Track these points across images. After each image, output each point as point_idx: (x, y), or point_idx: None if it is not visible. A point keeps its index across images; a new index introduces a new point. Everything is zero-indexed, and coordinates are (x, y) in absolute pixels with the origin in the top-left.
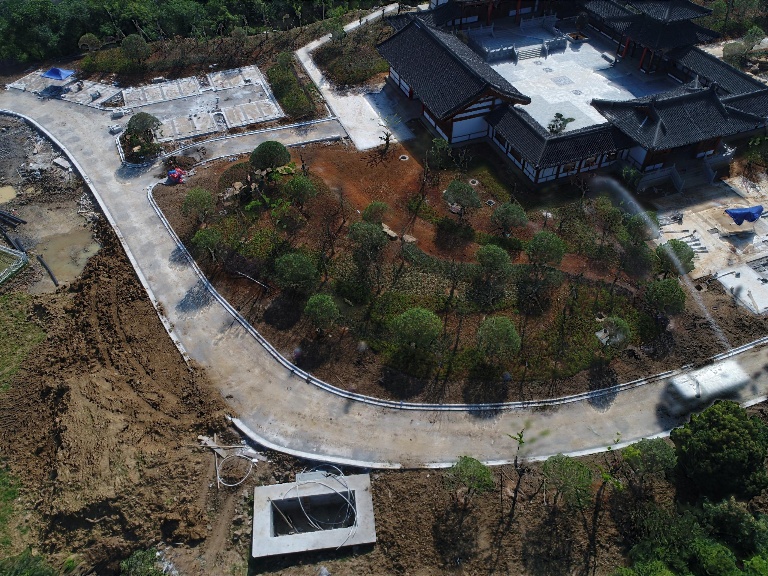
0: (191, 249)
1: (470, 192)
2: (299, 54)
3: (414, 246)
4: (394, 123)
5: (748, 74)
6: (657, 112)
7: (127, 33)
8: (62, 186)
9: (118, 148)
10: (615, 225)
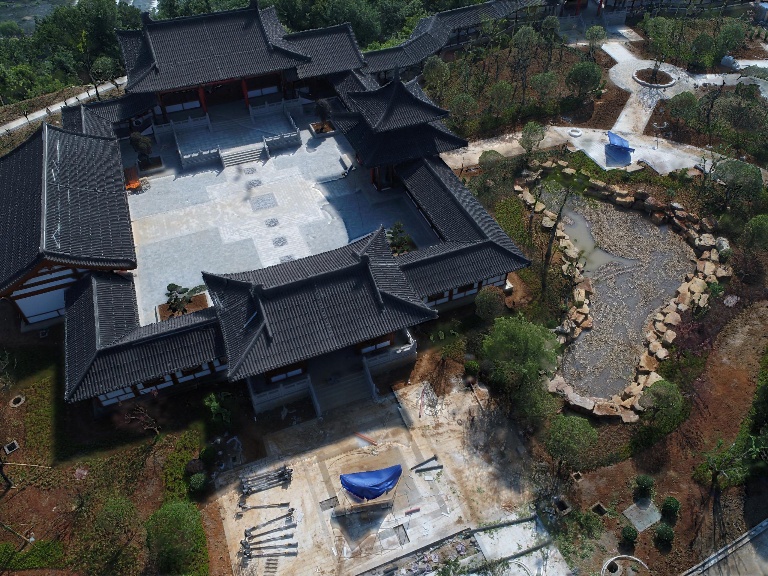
0: None
1: None
2: None
3: None
4: None
5: (516, 190)
6: (267, 305)
7: None
8: None
9: None
10: (173, 497)
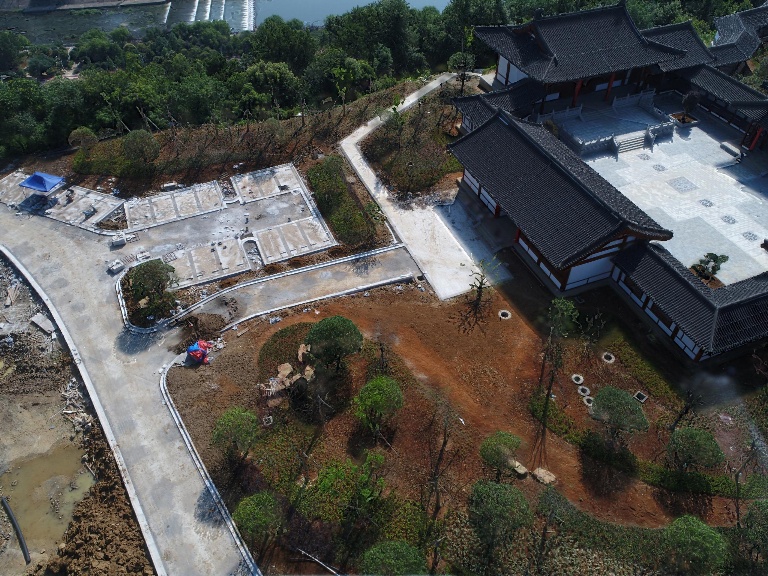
0: (226, 495)
1: (634, 409)
2: (344, 146)
3: (555, 492)
4: (480, 254)
5: None
6: None
7: (130, 119)
8: (42, 364)
9: (119, 299)
10: None
